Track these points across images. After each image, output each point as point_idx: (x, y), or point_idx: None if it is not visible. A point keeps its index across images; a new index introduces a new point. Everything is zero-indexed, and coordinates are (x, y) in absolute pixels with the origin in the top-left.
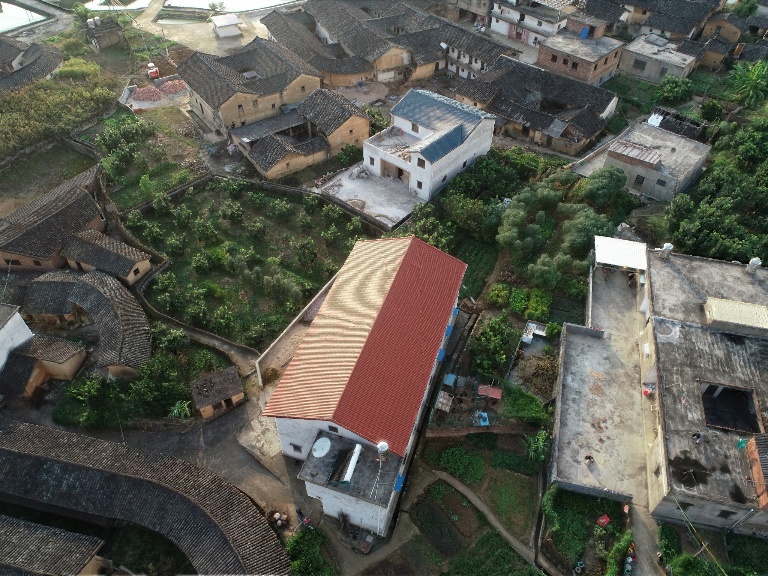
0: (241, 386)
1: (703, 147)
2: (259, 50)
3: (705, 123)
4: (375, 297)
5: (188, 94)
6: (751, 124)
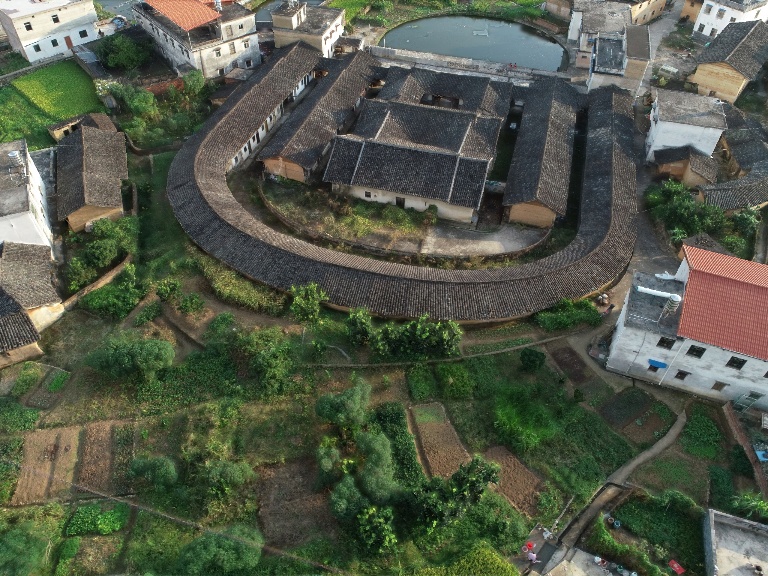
0: None
1: None
2: None
3: None
4: None
5: None
6: None
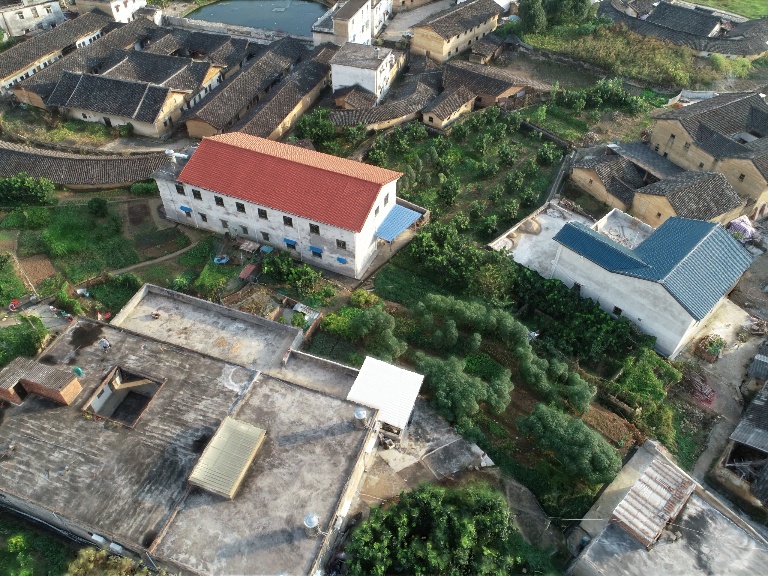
0: None
1: None
2: None
3: None
4: (312, 163)
5: None
6: None
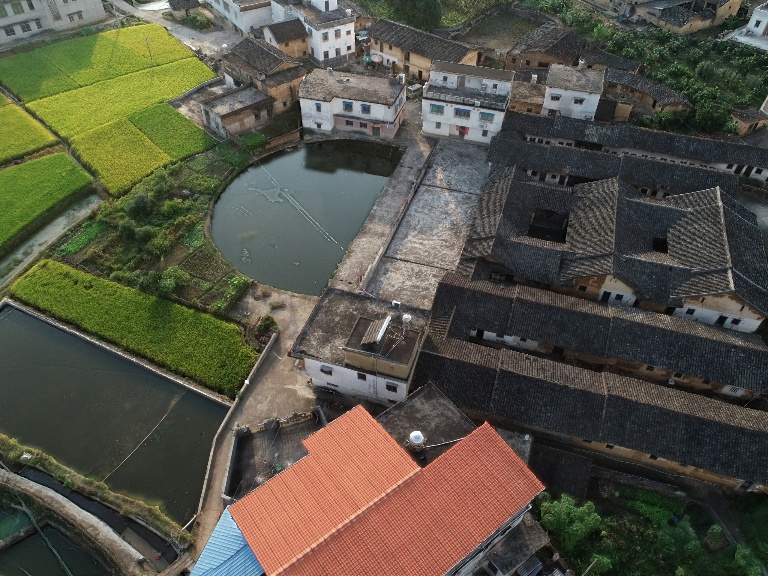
0: (766, 116)
1: None
2: None
3: None
4: None
5: None
6: None
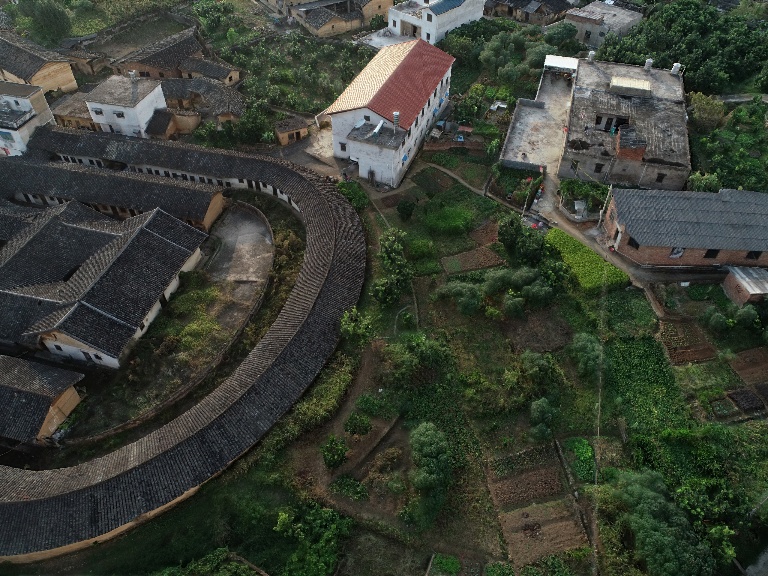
0: (306, 124)
1: (637, 14)
2: None
3: (645, 5)
4: (394, 64)
5: None
6: (676, 2)
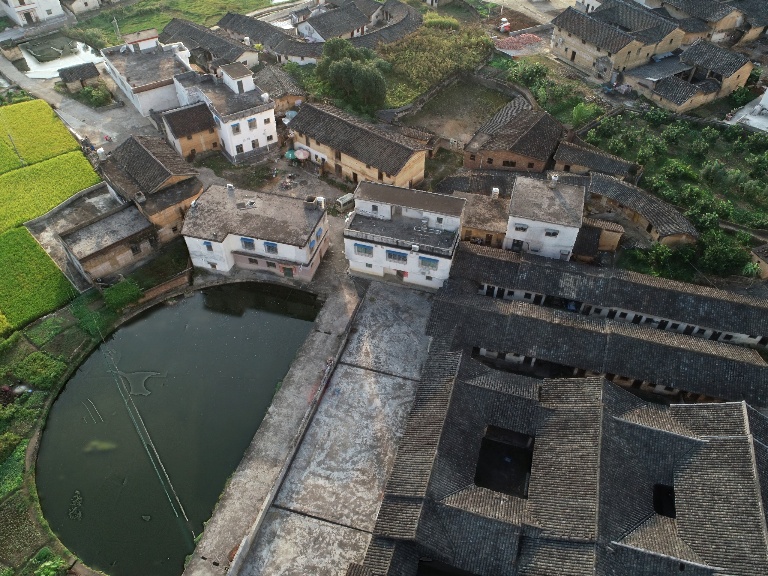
0: None
1: None
2: (619, 8)
3: None
4: None
5: (552, 44)
6: None
